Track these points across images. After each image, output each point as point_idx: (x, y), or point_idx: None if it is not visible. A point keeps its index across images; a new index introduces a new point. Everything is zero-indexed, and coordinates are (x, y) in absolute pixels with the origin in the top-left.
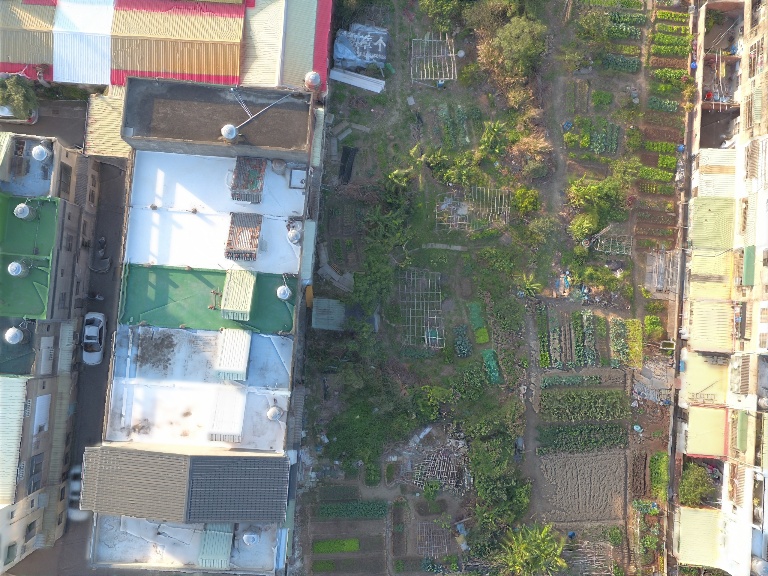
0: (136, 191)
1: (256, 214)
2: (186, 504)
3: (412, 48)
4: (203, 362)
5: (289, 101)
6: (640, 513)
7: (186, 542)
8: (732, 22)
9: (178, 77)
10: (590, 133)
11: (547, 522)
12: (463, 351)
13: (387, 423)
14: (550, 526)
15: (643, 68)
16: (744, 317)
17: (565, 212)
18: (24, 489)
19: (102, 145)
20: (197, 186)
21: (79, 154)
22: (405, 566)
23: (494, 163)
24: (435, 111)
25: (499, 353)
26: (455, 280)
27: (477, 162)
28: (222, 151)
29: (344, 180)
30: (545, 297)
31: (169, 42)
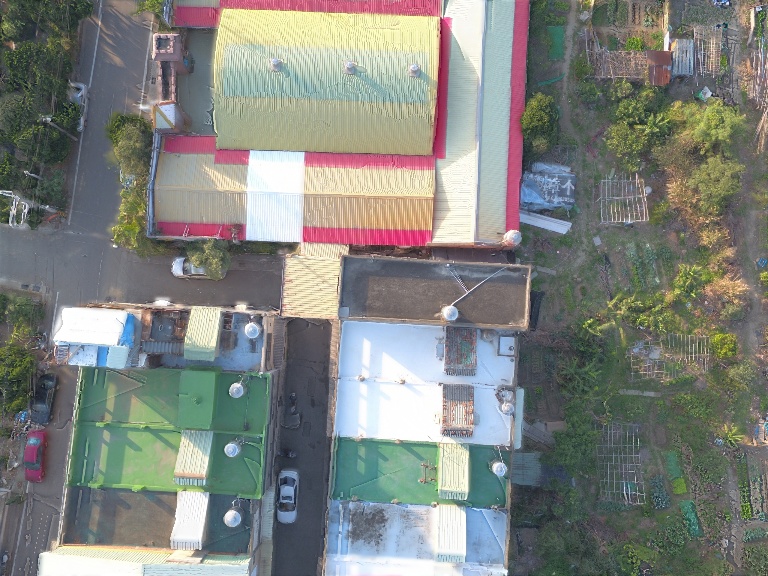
0: (343, 362)
1: (467, 385)
2: None
3: (601, 190)
4: (415, 537)
5: (505, 274)
6: None
7: None
8: None
9: (370, 233)
10: None
11: None
12: (661, 503)
13: None
14: None
15: None
16: None
17: (762, 354)
18: None
19: (299, 307)
20: (404, 355)
21: (276, 316)
22: None
23: (686, 304)
24: (623, 251)
25: (697, 504)
26: (649, 428)
27: (669, 304)
28: None
29: (531, 325)
30: (744, 444)
31: (362, 199)
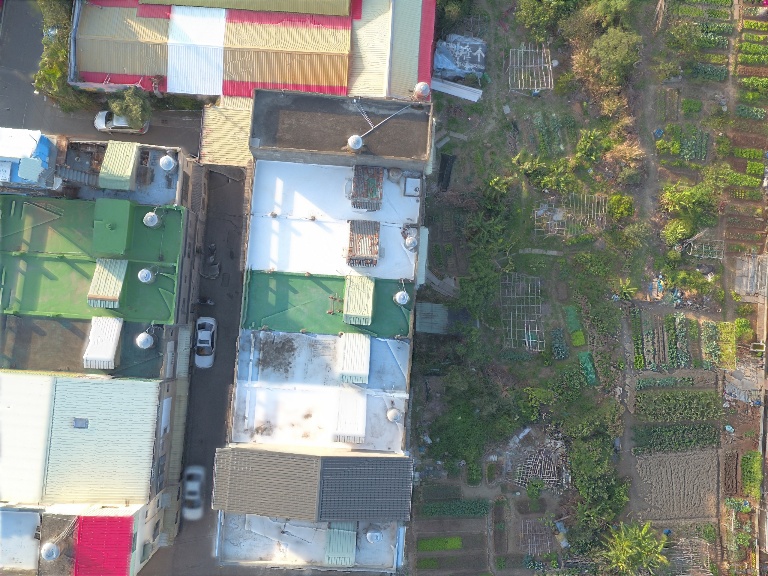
0: (256, 199)
1: (374, 221)
2: (318, 503)
3: (510, 58)
4: (323, 365)
5: (409, 112)
6: (732, 511)
7: (308, 540)
8: None
9: (288, 88)
10: (680, 140)
11: (643, 520)
12: (561, 353)
13: (489, 424)
14: (647, 524)
15: (730, 76)
16: None
17: (657, 217)
18: (154, 489)
19: (217, 154)
20: (315, 194)
21: (194, 163)
22: (506, 563)
23: (588, 170)
24: (530, 119)
25: (595, 355)
26: (551, 284)
27: (572, 169)
28: (342, 160)
29: (443, 187)
30: (638, 300)
31: (280, 54)
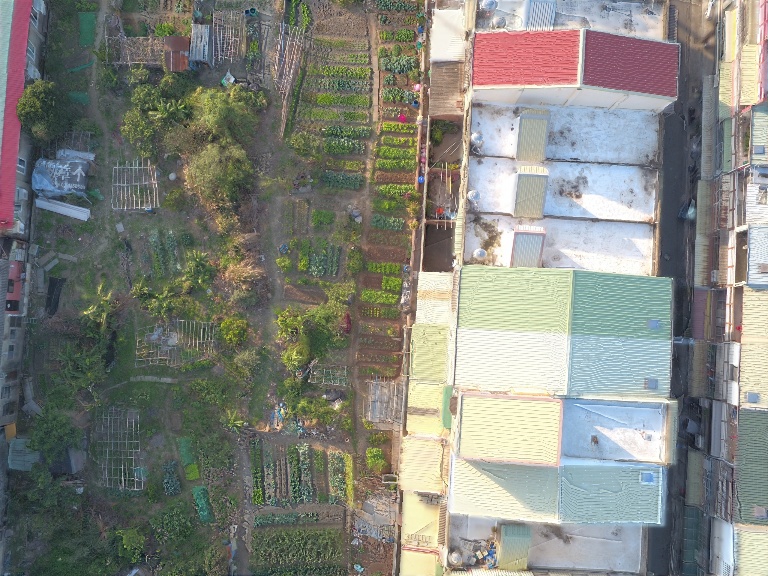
0: None
1: None
2: None
3: (113, 176)
4: None
5: None
6: None
7: None
8: (461, 133)
9: None
10: (309, 255)
11: None
12: (170, 489)
13: (88, 566)
14: None
15: (368, 184)
16: (442, 462)
17: (281, 340)
18: None
19: None
20: None
21: None
22: None
23: (207, 290)
24: (145, 238)
25: (210, 490)
26: (165, 414)
27: (187, 291)
28: None
29: (50, 312)
30: None
31: None
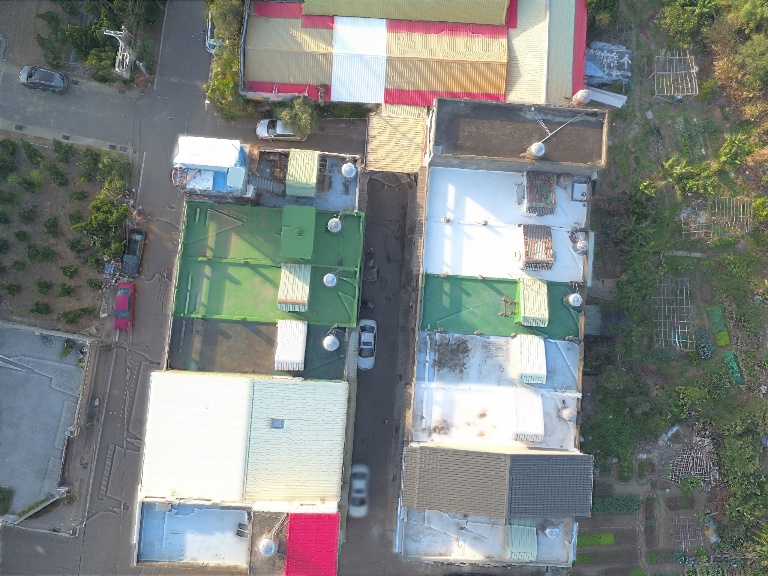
0: (429, 205)
1: (545, 226)
2: (507, 500)
3: (655, 65)
4: (496, 366)
5: (583, 119)
6: None
7: (486, 536)
8: None
9: (447, 95)
10: None
11: None
12: (707, 353)
13: (640, 422)
14: None
15: None
16: None
17: None
18: None
19: (383, 161)
20: (485, 200)
21: None
22: (658, 558)
23: (729, 173)
24: (672, 124)
25: (739, 355)
26: (696, 285)
27: (714, 173)
28: (517, 167)
29: None
30: None
31: (441, 62)
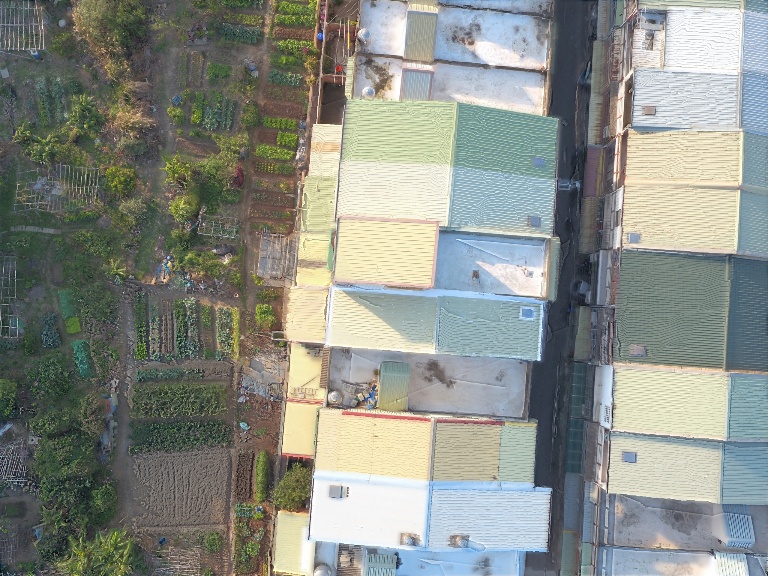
0: None
1: None
2: None
3: None
4: None
5: None
6: (244, 517)
7: None
8: None
9: None
10: (203, 108)
11: (138, 526)
12: (48, 341)
13: None
14: None
15: (266, 39)
16: (326, 304)
17: (171, 193)
18: None
19: None
20: None
21: None
22: None
23: (94, 140)
24: (32, 84)
25: (91, 344)
26: (46, 265)
27: (73, 139)
28: None
29: None
30: (146, 284)
31: None
